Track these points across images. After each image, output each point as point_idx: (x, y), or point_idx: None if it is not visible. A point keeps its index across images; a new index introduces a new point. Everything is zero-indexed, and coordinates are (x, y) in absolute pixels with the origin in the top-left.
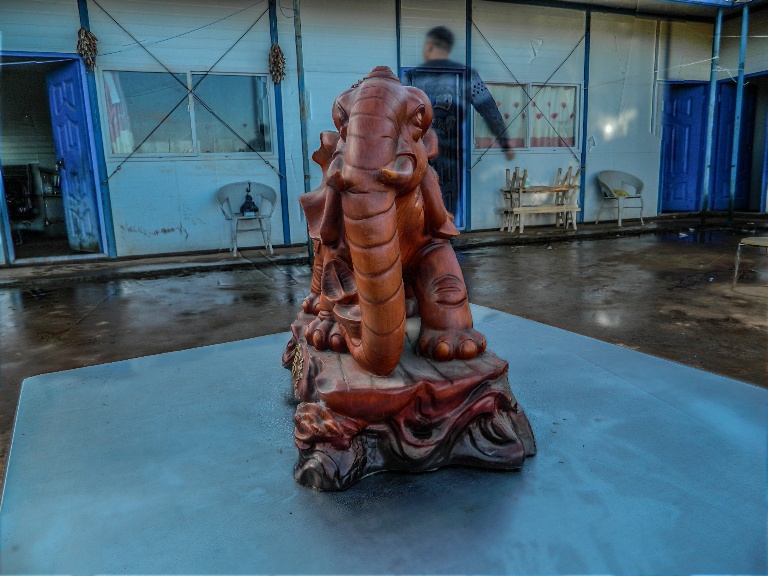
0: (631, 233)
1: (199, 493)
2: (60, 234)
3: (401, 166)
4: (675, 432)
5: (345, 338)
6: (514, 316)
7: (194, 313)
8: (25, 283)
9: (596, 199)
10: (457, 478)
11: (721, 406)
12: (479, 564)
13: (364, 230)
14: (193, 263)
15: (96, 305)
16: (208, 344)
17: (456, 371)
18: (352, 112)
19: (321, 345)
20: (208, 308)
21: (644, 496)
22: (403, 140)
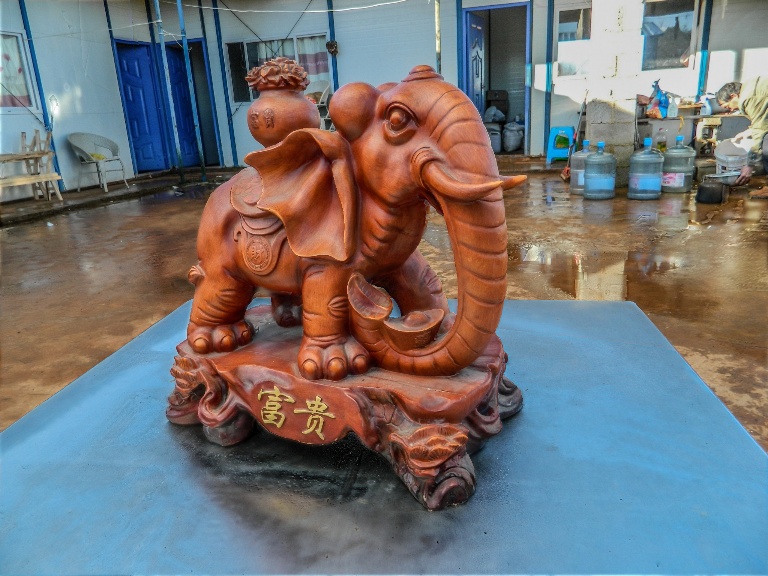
0: (129, 197)
1: None
2: None
3: None
4: (527, 343)
5: (387, 354)
6: None
7: None
8: None
9: (71, 164)
10: (507, 434)
11: (512, 318)
12: (621, 472)
13: (500, 236)
14: None
15: None
16: None
17: None
18: (457, 117)
19: (343, 373)
20: None
21: (589, 386)
22: None
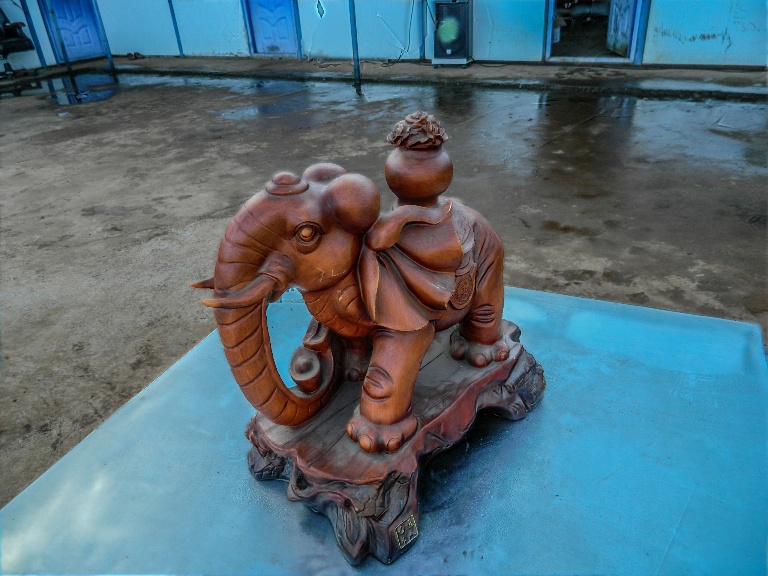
0: None
1: (217, 420)
2: (602, 30)
3: (250, 288)
4: None
5: None
6: (763, 384)
7: (648, 161)
8: (541, 87)
9: None
10: (314, 531)
11: None
12: None
13: None
14: (715, 85)
15: (572, 127)
16: (621, 208)
17: (337, 456)
18: None
19: None
20: (669, 157)
21: None
22: (276, 257)
